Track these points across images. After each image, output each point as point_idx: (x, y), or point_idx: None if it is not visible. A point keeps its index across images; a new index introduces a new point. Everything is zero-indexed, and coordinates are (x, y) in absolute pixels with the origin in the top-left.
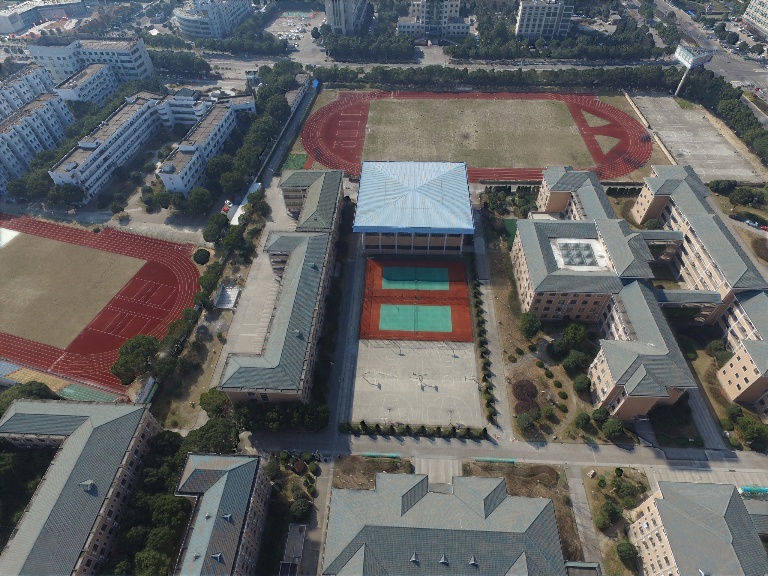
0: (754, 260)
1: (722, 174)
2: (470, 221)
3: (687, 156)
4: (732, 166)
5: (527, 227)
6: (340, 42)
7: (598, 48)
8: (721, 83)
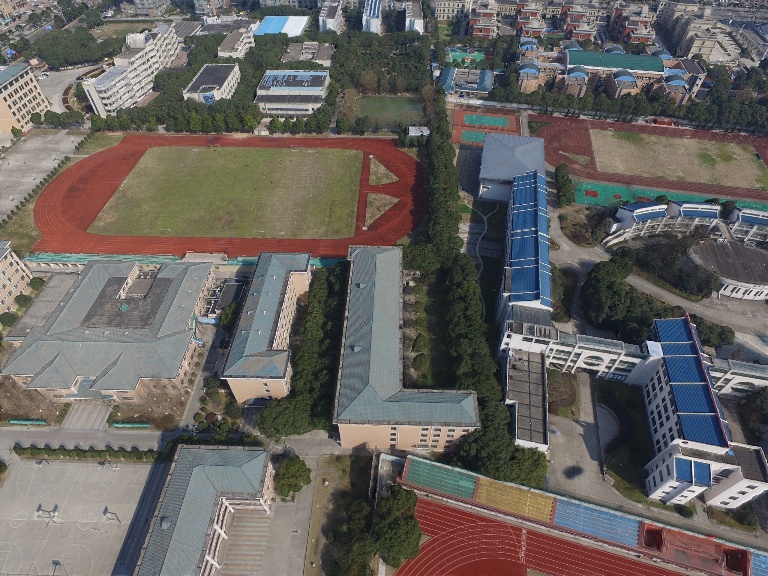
0: None
1: None
2: None
3: None
4: None
5: None
6: None
7: None
8: None
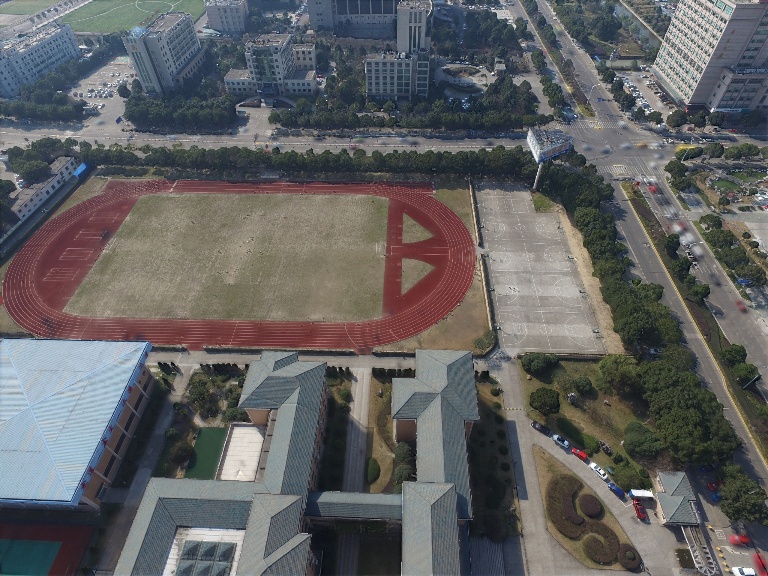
0: (541, 526)
1: (550, 335)
2: (75, 483)
3: (513, 299)
4: (569, 319)
5: (148, 505)
6: (137, 108)
7: (455, 117)
8: (582, 181)
